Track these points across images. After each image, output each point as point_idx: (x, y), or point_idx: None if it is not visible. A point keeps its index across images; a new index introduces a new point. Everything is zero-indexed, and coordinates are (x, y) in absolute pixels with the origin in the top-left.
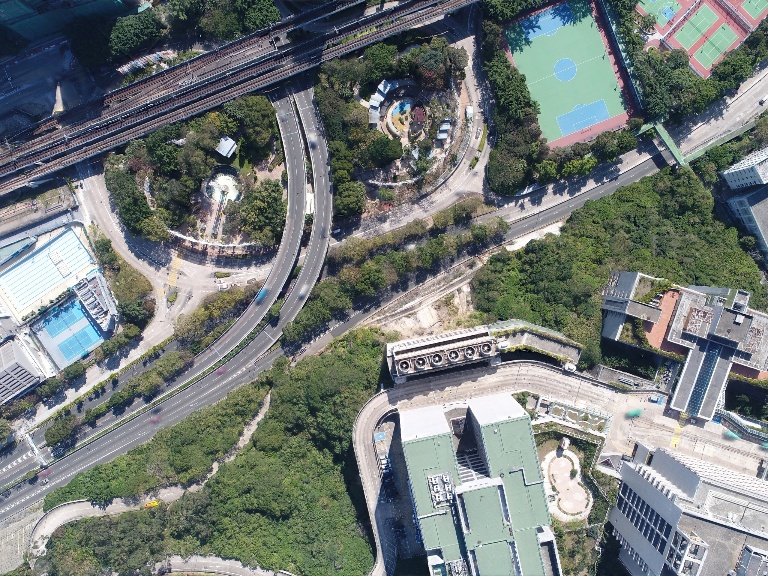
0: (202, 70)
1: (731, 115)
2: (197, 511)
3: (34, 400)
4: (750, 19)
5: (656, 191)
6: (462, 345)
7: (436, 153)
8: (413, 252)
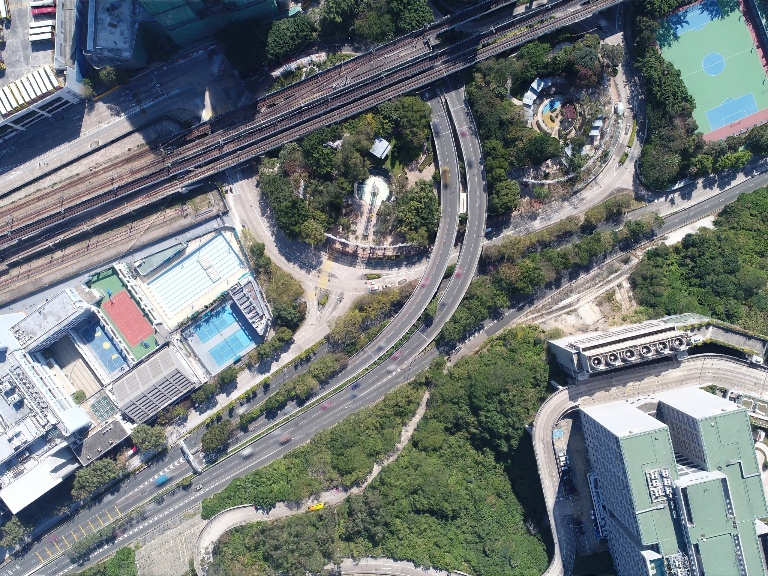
0: (356, 72)
1: None
2: (371, 513)
3: (188, 406)
4: None
5: None
6: (654, 340)
7: (586, 150)
8: (569, 249)
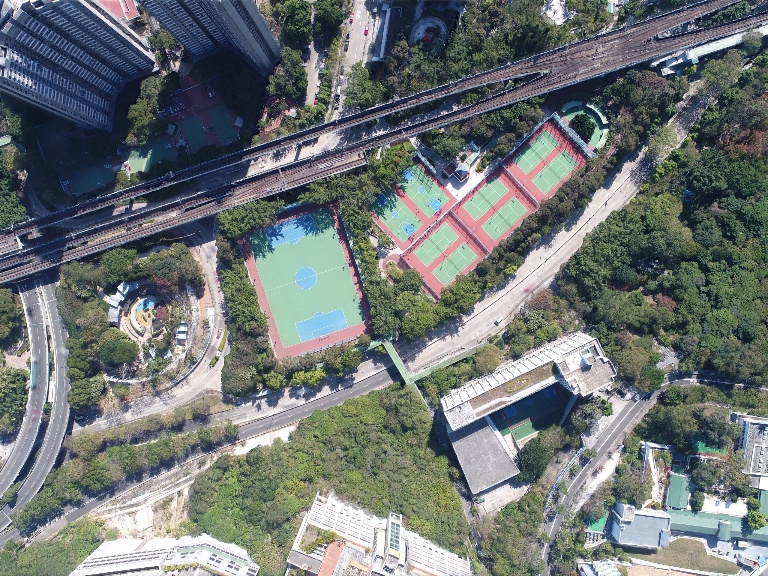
0: None
1: (466, 333)
2: None
3: None
4: (490, 240)
5: (382, 406)
6: None
7: (178, 350)
8: (142, 449)
